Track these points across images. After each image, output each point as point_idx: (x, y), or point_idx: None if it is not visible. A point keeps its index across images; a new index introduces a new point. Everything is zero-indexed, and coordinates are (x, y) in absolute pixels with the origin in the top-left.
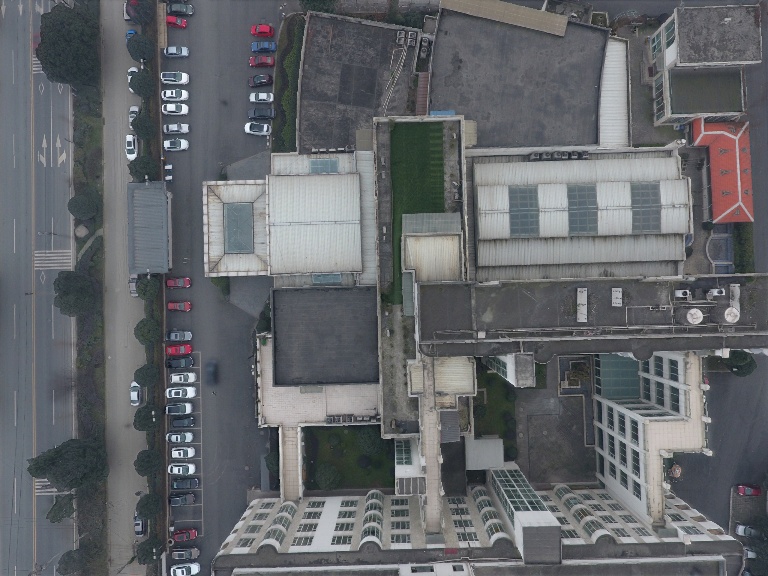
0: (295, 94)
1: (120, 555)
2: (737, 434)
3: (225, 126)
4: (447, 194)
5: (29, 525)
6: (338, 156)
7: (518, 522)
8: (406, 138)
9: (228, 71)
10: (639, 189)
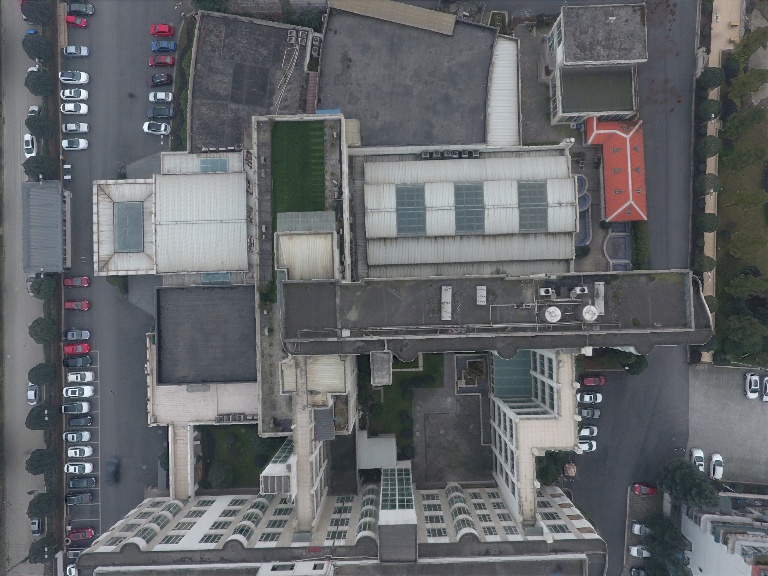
0: None
1: (18, 554)
2: (634, 433)
3: (125, 125)
4: (328, 193)
5: None
6: (228, 155)
7: None
8: (287, 137)
9: (128, 70)
10: (526, 188)
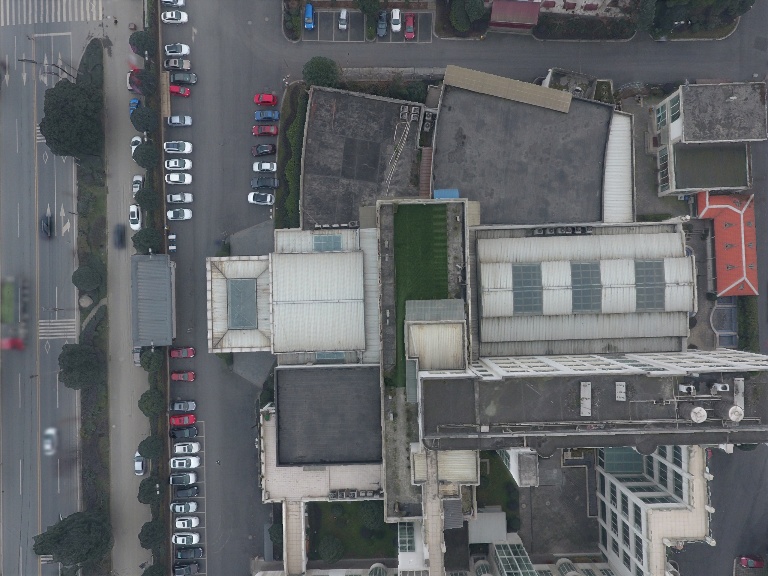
0: (298, 165)
1: None
2: (740, 505)
3: (228, 195)
4: (450, 276)
5: None
6: (341, 232)
7: None
8: (409, 220)
9: (231, 140)
10: (643, 267)
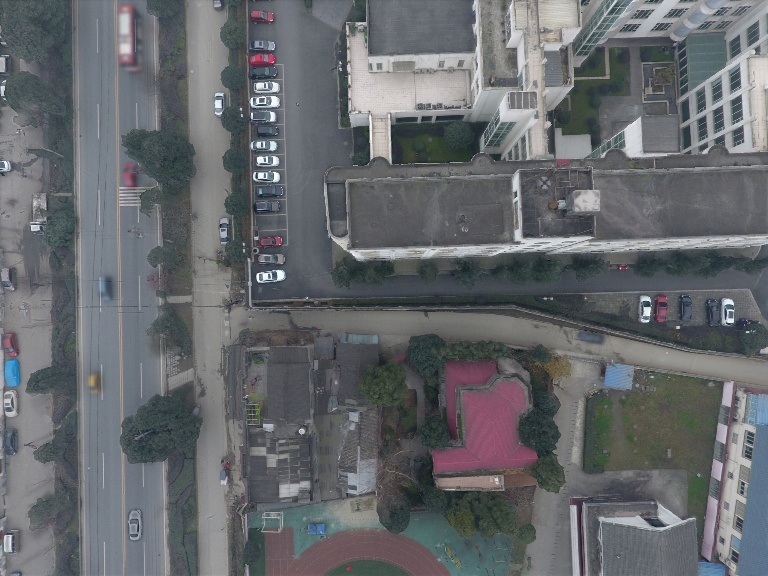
0: None
1: (204, 266)
2: None
3: None
4: None
5: (113, 236)
6: None
7: (633, 124)
8: None
9: None
10: None
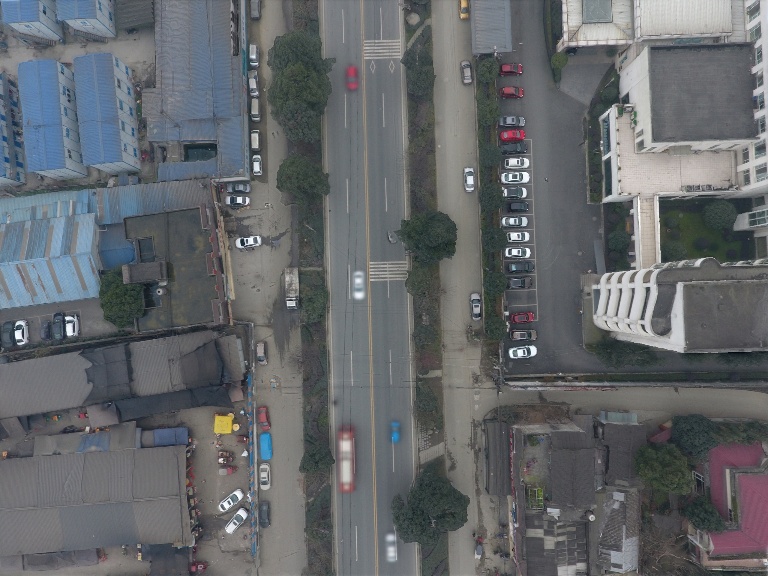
0: None
1: (453, 341)
2: None
3: None
4: None
5: (364, 310)
6: None
7: None
8: None
9: None
10: None
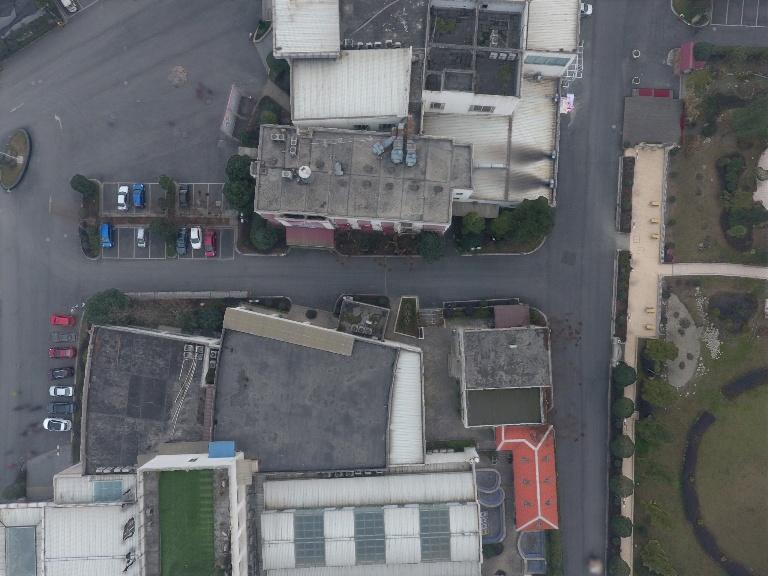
0: None
1: None
2: None
3: (25, 419)
4: (217, 543)
5: None
6: (122, 478)
7: None
8: (175, 484)
9: (29, 361)
10: (428, 515)
